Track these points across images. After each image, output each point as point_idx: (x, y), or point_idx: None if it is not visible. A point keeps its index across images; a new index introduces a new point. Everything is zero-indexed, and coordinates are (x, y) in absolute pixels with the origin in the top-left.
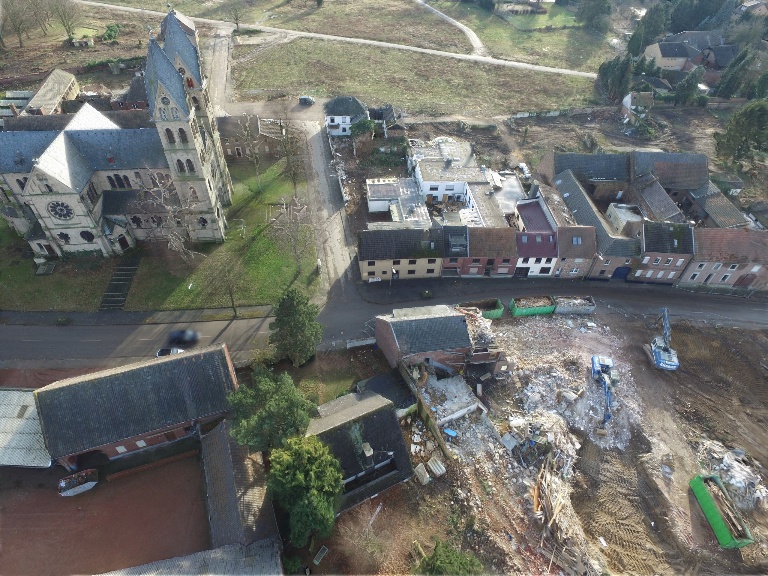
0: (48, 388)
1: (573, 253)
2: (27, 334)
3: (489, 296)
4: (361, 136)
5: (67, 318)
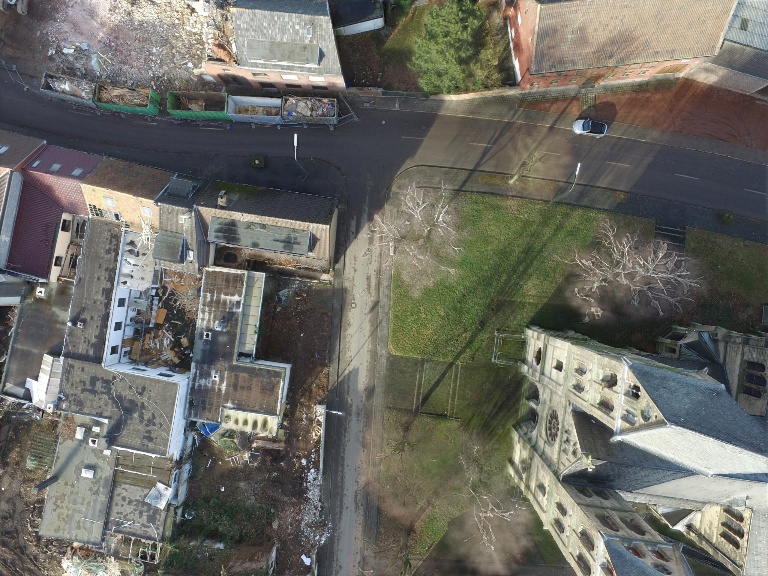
0: (728, 5)
1: (20, 140)
2: (765, 204)
3: (176, 143)
4: (251, 570)
5: (723, 218)
